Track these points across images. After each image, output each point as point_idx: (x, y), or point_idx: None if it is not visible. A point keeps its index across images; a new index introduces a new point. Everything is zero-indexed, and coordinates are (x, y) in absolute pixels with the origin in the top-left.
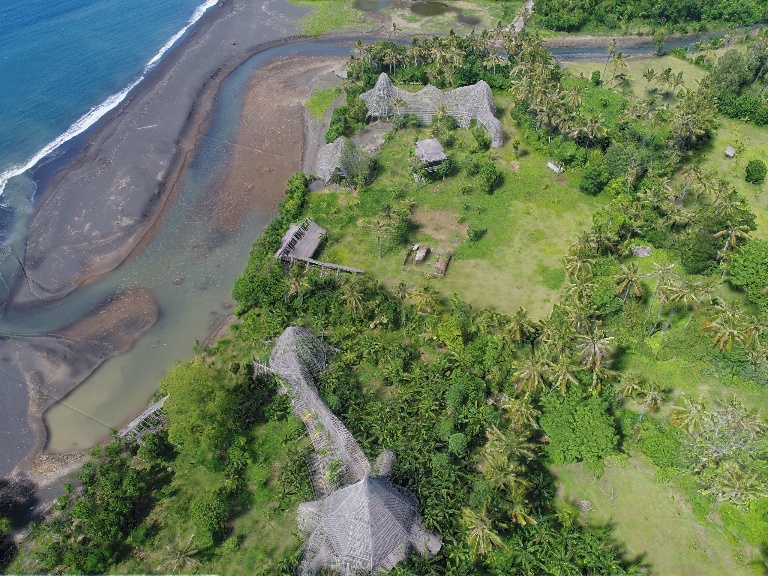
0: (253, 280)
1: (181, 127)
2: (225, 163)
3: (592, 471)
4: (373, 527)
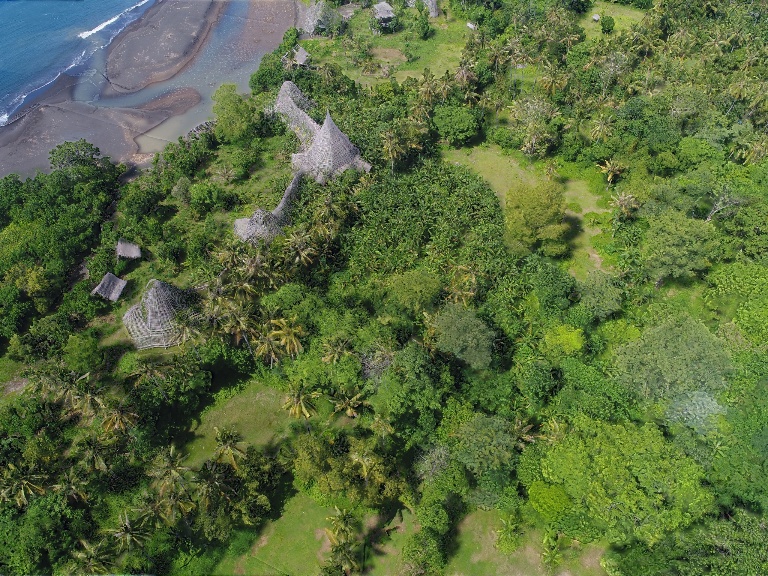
0: (263, 70)
1: (206, 8)
2: (240, 28)
3: (465, 152)
4: (332, 145)
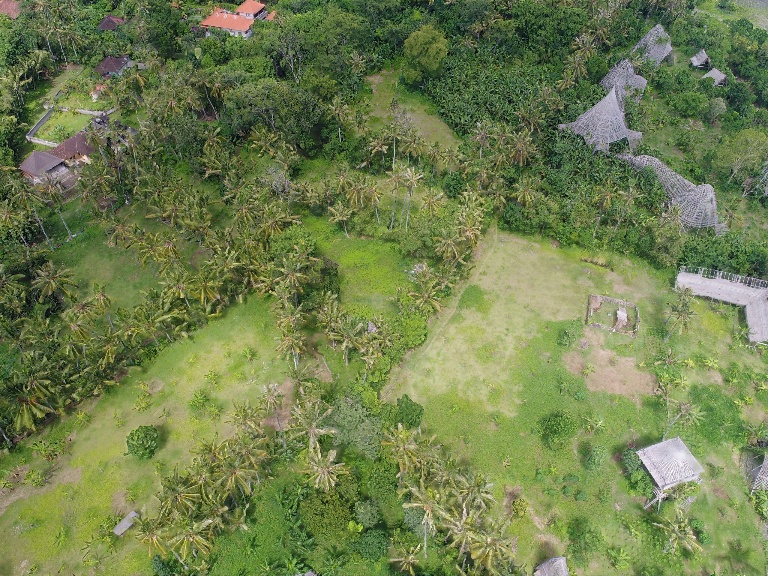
0: None
1: None
2: None
3: None
4: None
